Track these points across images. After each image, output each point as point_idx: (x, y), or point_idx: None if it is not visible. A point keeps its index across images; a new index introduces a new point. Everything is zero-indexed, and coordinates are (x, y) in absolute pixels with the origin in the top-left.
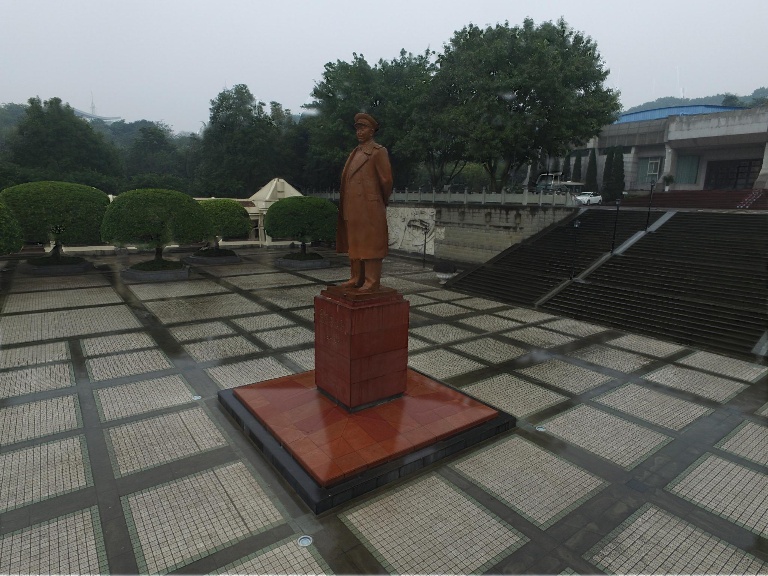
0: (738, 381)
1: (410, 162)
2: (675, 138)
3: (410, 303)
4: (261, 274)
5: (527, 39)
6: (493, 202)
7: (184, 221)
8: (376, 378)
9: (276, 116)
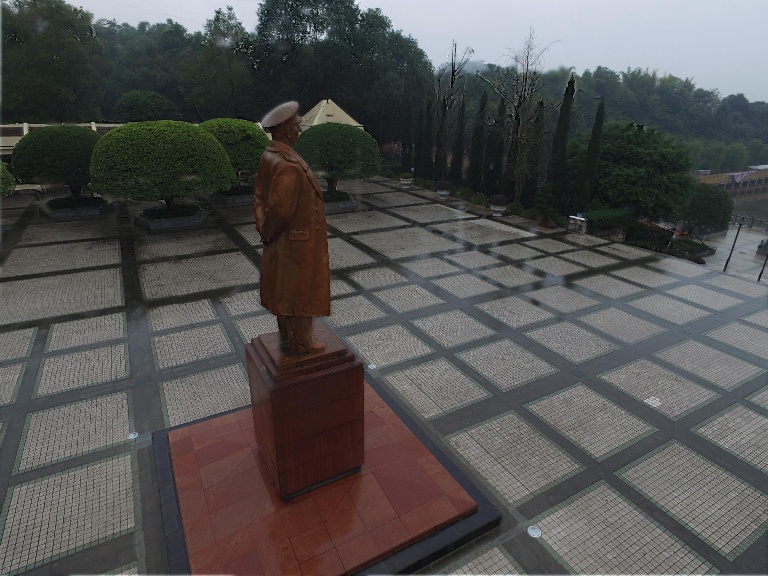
0: None
1: None
2: None
3: None
4: None
5: None
6: None
7: None
8: None
9: None
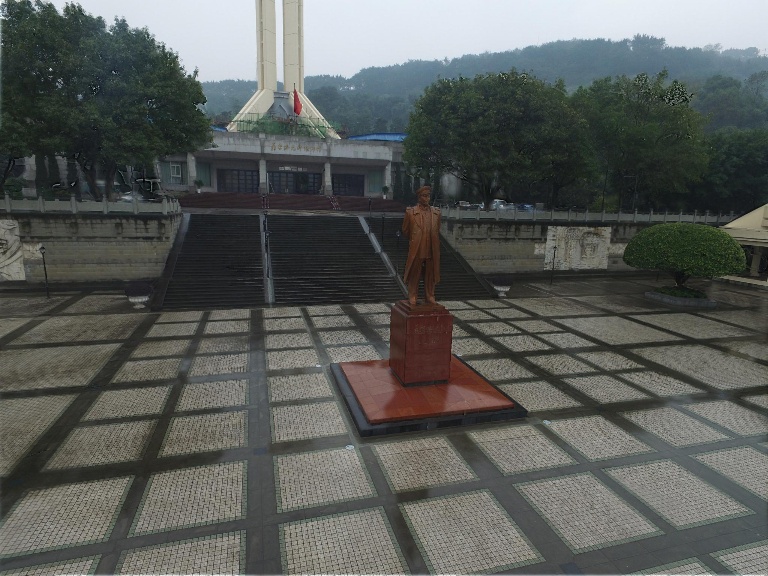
0: None
1: None
2: None
3: (186, 332)
4: None
5: (133, 43)
6: (121, 211)
7: None
8: None
9: None
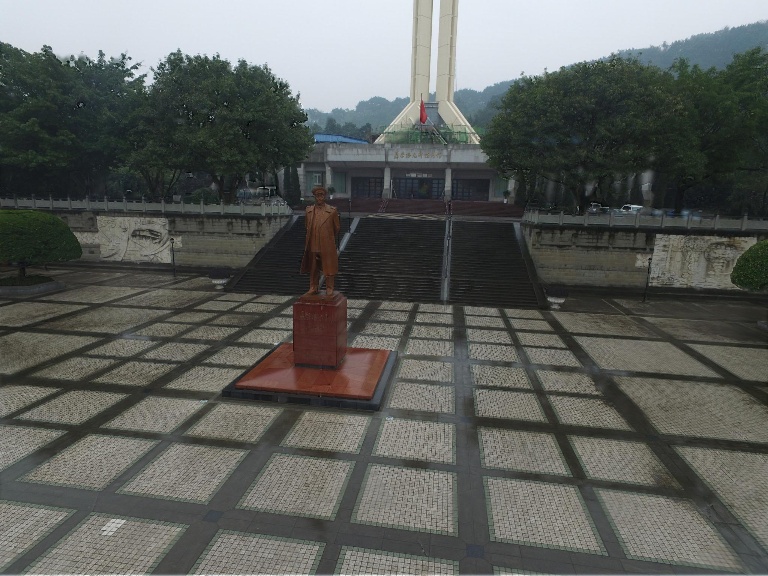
0: (448, 314)
1: (110, 167)
2: (332, 160)
3: (223, 308)
4: None
5: (247, 78)
6: (232, 213)
7: None
8: (341, 346)
9: None
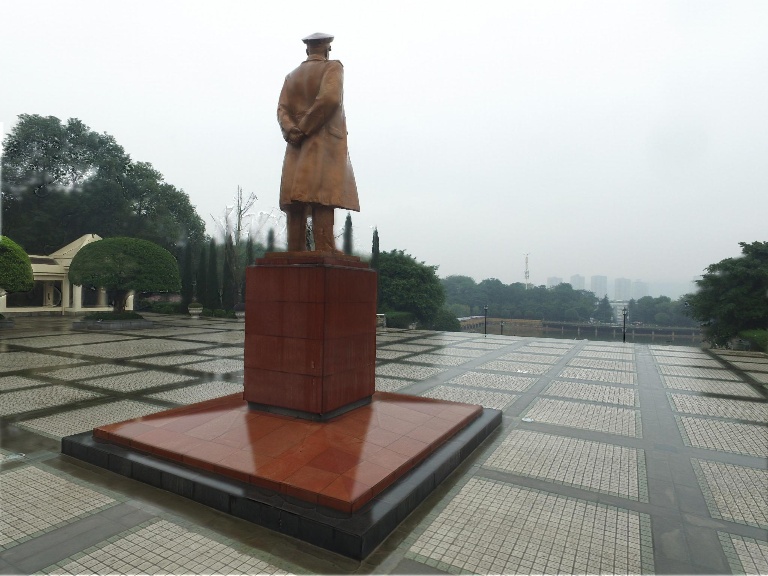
0: None
1: None
2: None
3: None
4: None
5: None
6: None
7: None
8: None
9: None
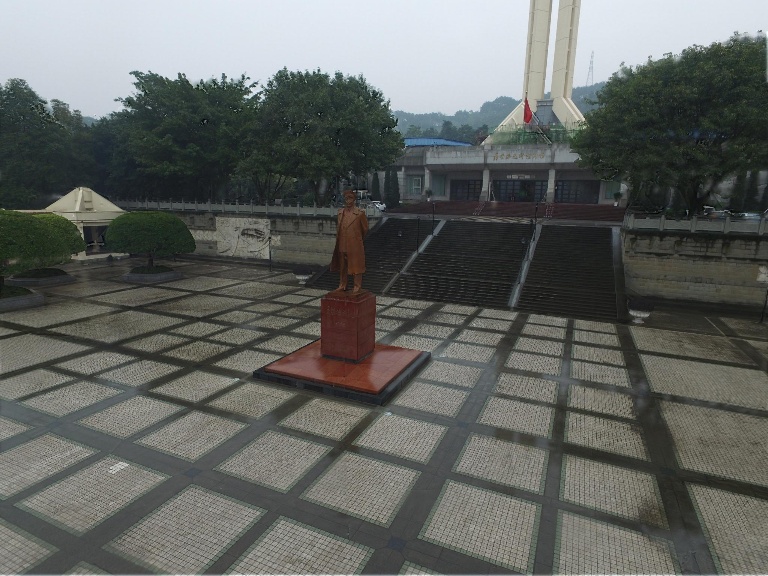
0: (508, 321)
1: (230, 174)
2: (431, 163)
3: (296, 301)
4: (124, 290)
5: (341, 89)
6: (324, 215)
7: (43, 244)
8: (365, 342)
9: (61, 116)
